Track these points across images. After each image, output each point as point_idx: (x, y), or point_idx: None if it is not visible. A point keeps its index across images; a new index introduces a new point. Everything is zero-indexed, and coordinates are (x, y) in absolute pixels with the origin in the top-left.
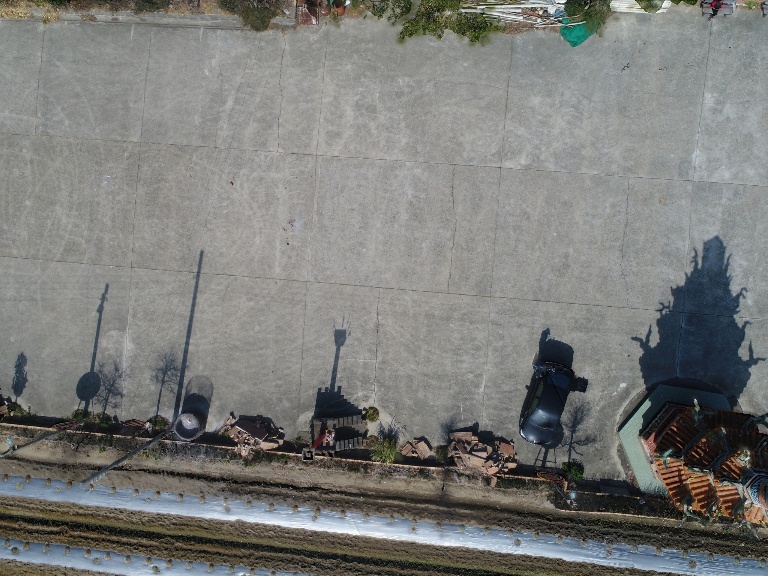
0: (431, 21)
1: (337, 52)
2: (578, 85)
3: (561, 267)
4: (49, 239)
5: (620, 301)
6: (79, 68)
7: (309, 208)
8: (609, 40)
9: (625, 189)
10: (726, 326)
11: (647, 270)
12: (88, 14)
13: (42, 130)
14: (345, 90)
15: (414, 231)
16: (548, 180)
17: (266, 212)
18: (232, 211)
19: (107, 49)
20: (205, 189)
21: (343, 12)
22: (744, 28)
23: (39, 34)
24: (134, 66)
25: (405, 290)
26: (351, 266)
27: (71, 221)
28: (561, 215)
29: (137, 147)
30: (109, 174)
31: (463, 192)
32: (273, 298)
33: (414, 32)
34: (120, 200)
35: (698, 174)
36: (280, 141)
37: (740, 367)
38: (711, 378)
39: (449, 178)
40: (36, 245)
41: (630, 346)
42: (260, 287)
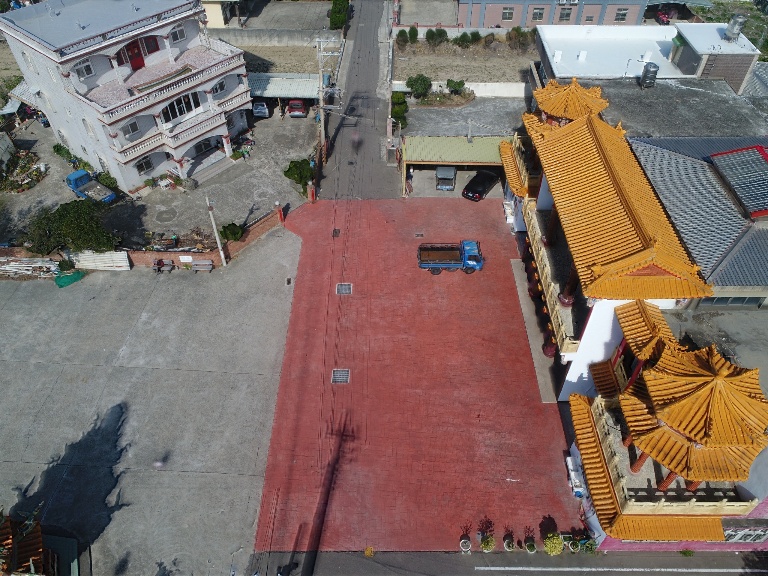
0: None
1: None
2: (53, 308)
3: None
4: None
5: (16, 456)
6: None
7: None
8: (87, 285)
9: (59, 372)
10: (103, 476)
11: (51, 430)
12: None
13: None
14: None
15: None
16: (0, 366)
17: None
18: None
19: None
20: None
21: None
22: (181, 279)
23: None
24: None
25: None
26: None
27: None
28: None
29: None
30: None
31: None
32: None
33: None
34: None
35: (120, 362)
36: None
37: (103, 513)
38: (72, 525)
39: None
40: None
41: (8, 496)
42: None
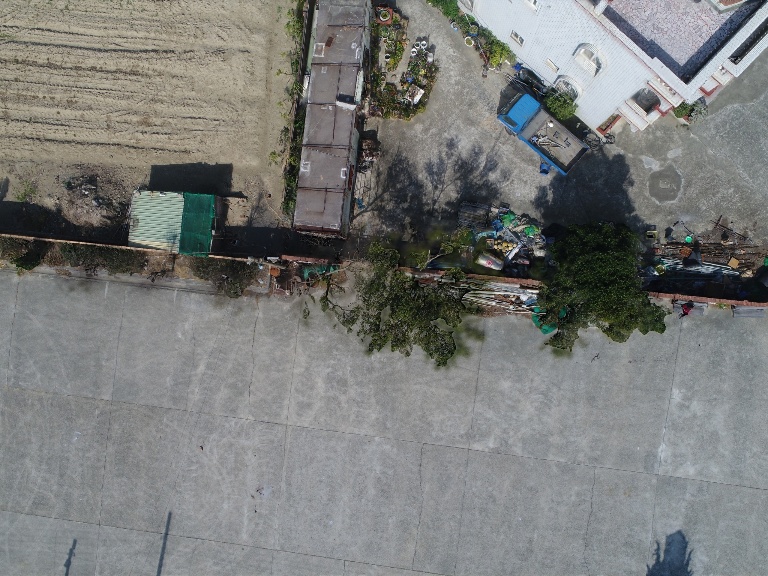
0: (400, 336)
1: (310, 323)
2: (548, 372)
3: (525, 552)
4: (18, 491)
5: None
6: (52, 322)
7: (278, 477)
8: (580, 329)
9: (591, 478)
10: None
11: (609, 560)
12: (62, 269)
13: (14, 382)
14: (317, 362)
15: (381, 507)
16: (515, 465)
17: (235, 478)
18: (201, 475)
19: (81, 305)
20: (175, 451)
21: (317, 285)
22: (714, 326)
23: (13, 285)
24: (107, 324)
25: (370, 564)
26: (317, 537)
27: (40, 475)
28: (527, 500)
29: (108, 405)
30: (80, 430)
31: (431, 471)
32: (239, 564)
33: (383, 345)
34: (90, 457)
35: (663, 468)
36: (251, 409)
37: None
38: None
39: (417, 456)
40: (5, 496)
41: None
42: (227, 552)
